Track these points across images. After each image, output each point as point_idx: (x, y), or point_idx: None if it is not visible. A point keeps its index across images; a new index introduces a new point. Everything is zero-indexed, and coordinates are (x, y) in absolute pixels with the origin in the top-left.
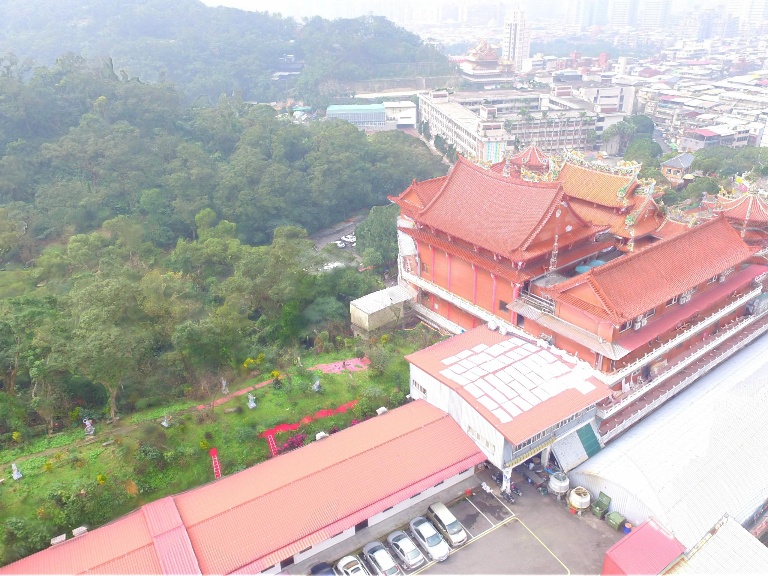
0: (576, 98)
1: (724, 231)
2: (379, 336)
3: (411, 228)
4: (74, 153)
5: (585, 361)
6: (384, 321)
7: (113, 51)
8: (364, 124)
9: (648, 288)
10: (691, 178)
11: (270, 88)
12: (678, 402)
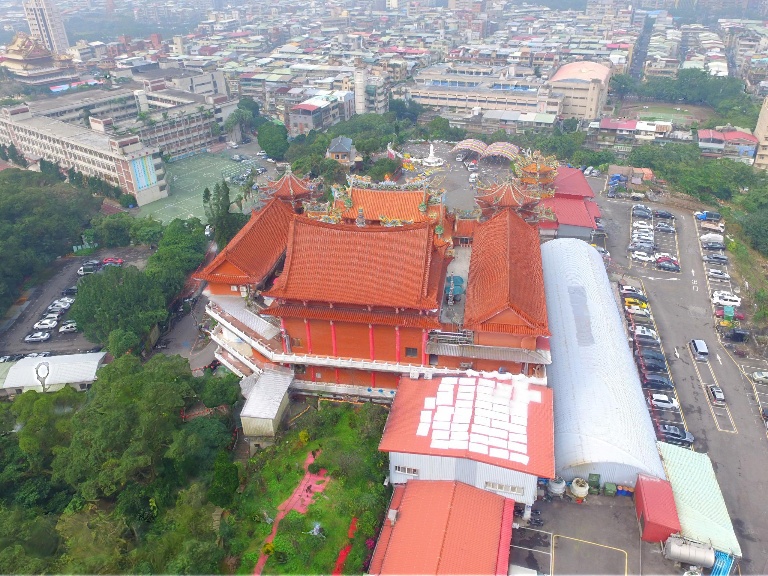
0: (174, 90)
1: (516, 220)
2: (282, 435)
3: (272, 307)
4: None
5: None
6: (279, 417)
7: None
8: None
9: (530, 292)
10: (361, 160)
11: None
12: (557, 370)
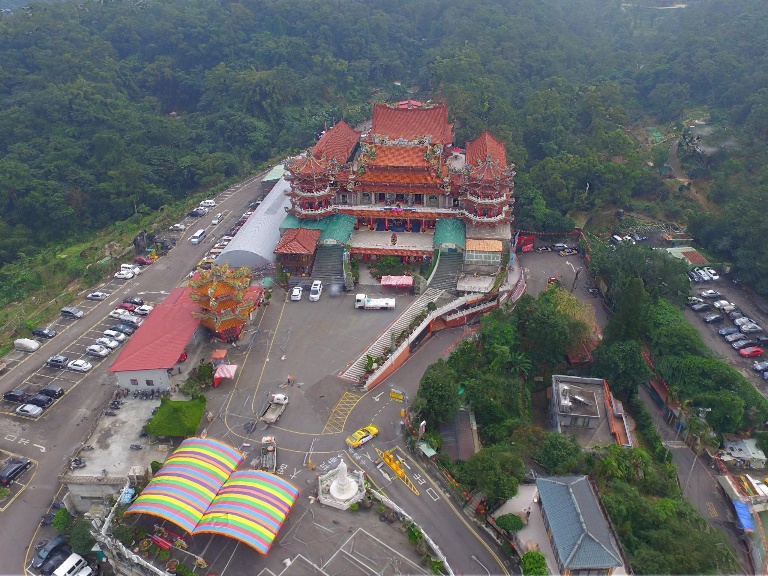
0: None
1: None
2: None
3: (451, 133)
4: None
5: None
6: None
7: None
8: None
9: None
10: None
11: None
12: None
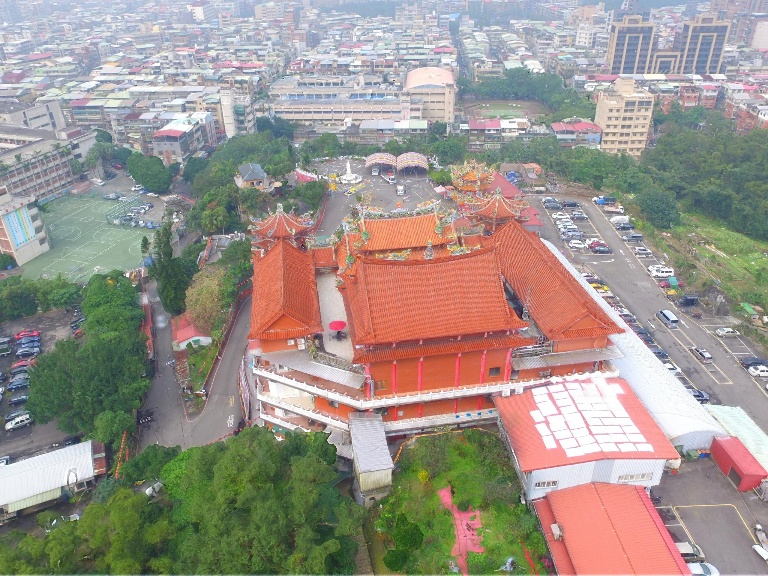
0: (6, 127)
1: None
2: None
3: (361, 355)
4: None
5: (590, 372)
6: None
7: None
8: None
9: None
10: (281, 185)
11: None
12: None
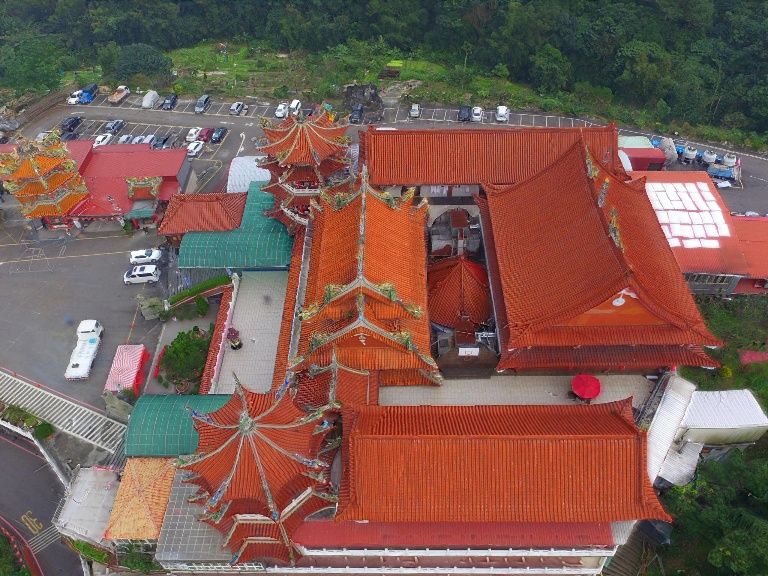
0: None
1: None
2: None
3: None
4: None
5: None
6: None
7: None
8: None
9: None
10: None
11: None
12: None
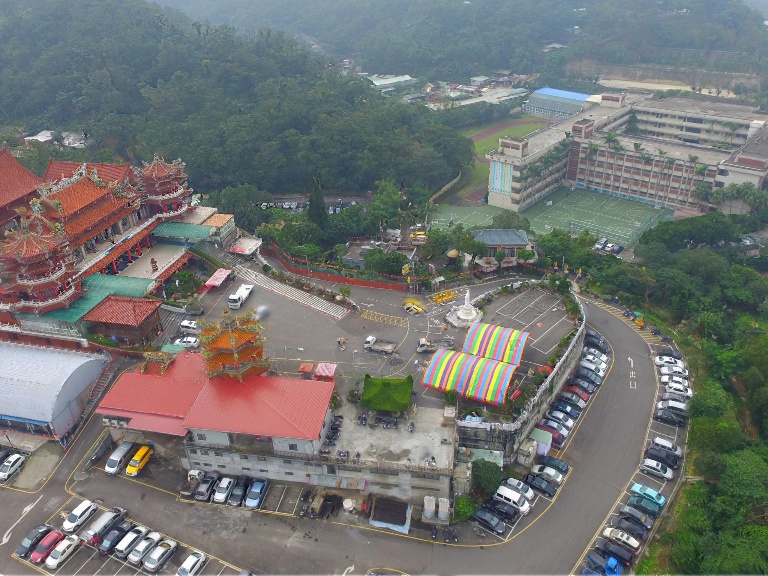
0: None
1: None
2: None
3: None
4: (148, 96)
5: None
6: None
7: (419, 10)
8: (559, 114)
9: None
10: (449, 255)
11: (523, 60)
12: None
